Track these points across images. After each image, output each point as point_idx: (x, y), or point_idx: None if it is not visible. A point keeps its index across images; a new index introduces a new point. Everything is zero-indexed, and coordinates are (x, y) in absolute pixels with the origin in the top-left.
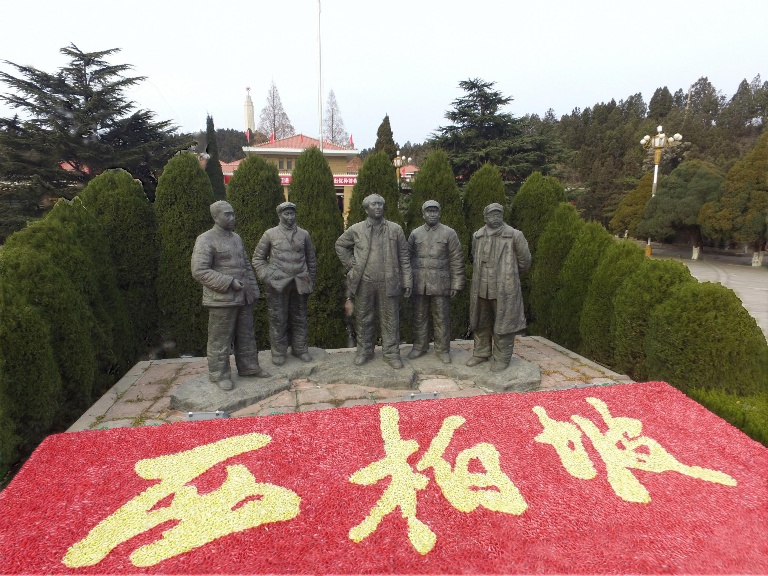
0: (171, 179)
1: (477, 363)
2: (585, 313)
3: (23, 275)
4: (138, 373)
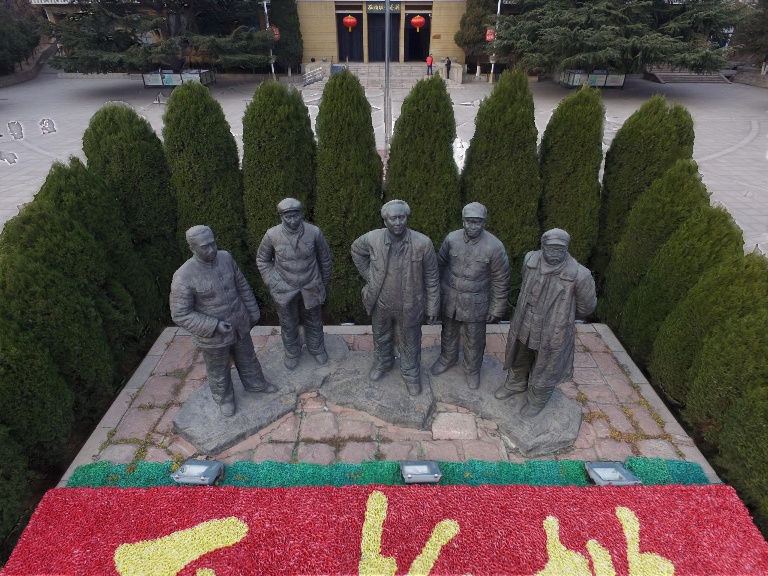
0: (175, 121)
1: (507, 396)
2: (665, 332)
3: (11, 295)
4: (160, 352)
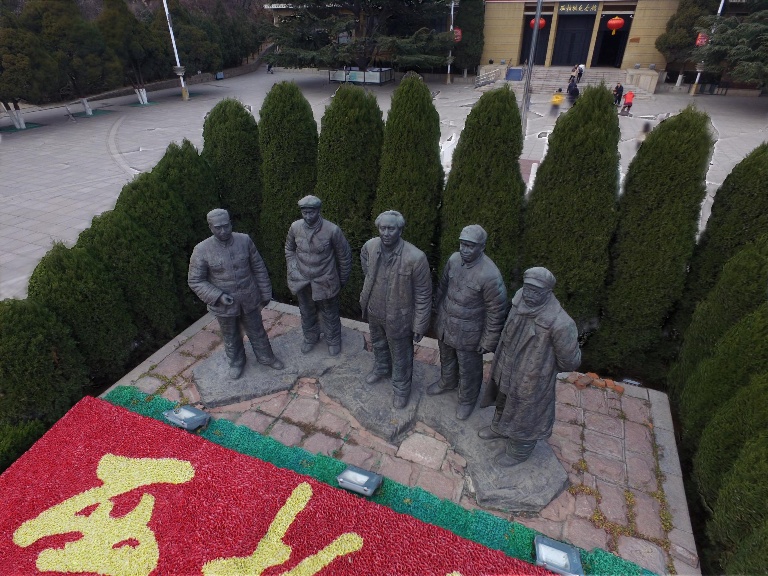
0: (265, 116)
1: (490, 437)
2: None
3: (105, 242)
4: None
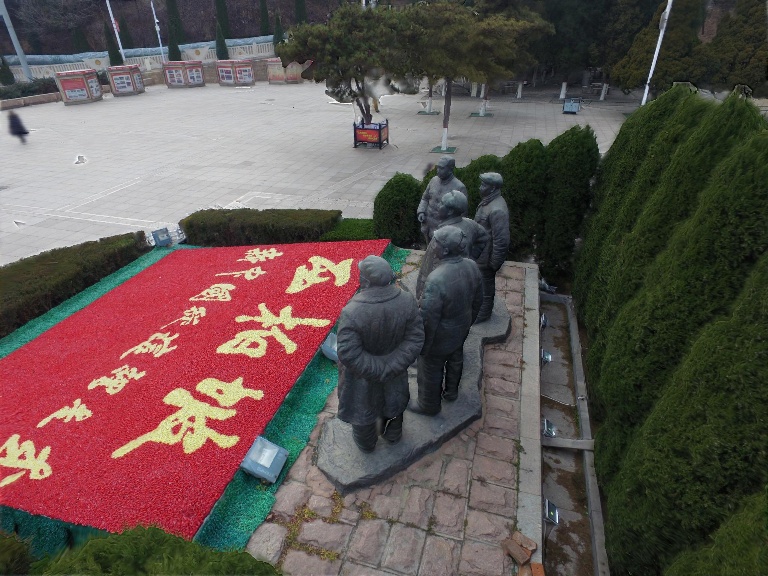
0: None
1: None
2: None
3: None
4: (505, 264)
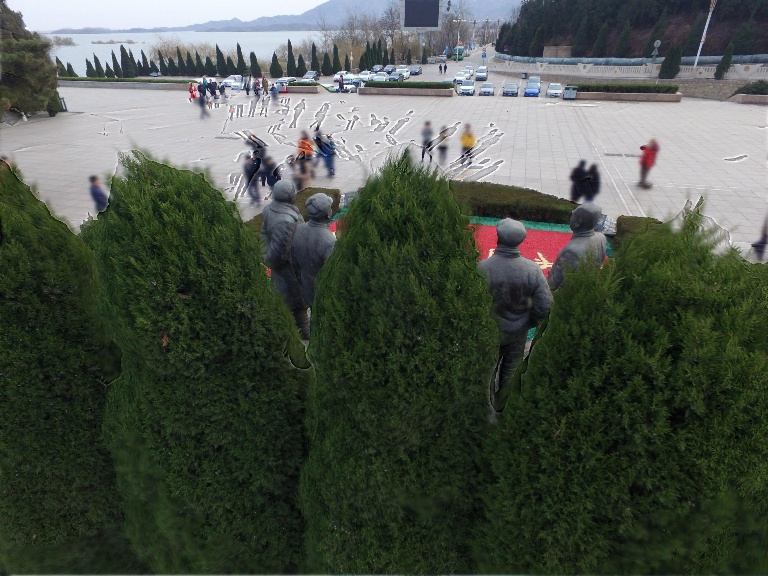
0: None
1: None
2: None
3: None
4: None
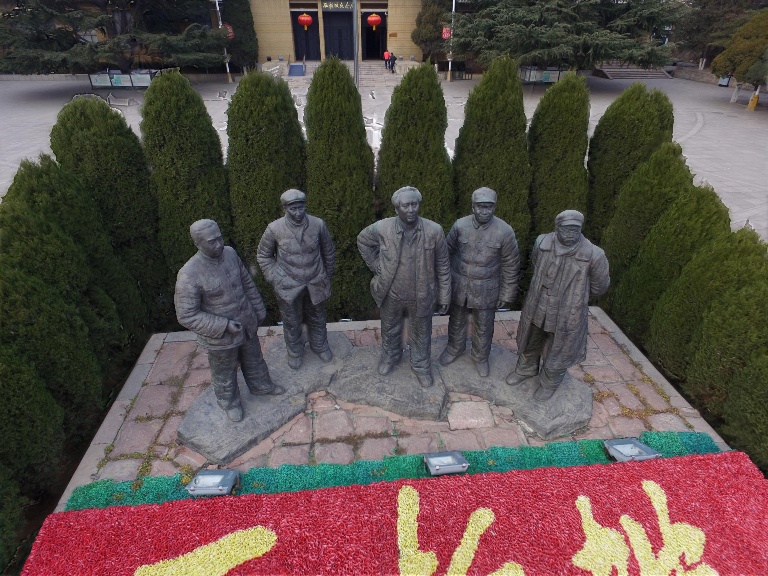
0: (154, 114)
1: (519, 382)
2: (662, 310)
3: None
4: (150, 360)
